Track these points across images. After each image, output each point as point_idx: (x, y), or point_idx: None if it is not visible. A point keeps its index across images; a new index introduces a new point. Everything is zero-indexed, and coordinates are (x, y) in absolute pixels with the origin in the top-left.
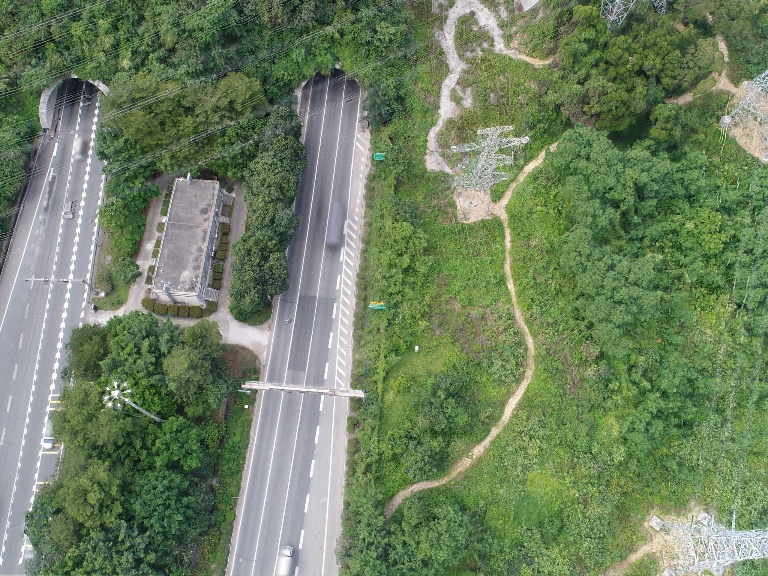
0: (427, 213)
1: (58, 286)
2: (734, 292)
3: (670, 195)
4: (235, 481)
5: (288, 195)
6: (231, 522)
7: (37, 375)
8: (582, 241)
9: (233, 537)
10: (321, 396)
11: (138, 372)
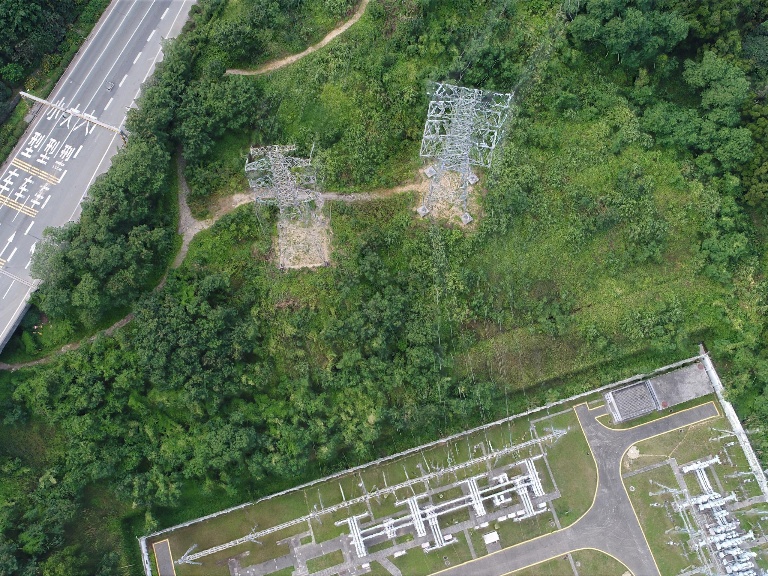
0: None
1: None
2: (565, 1)
3: None
4: (87, 26)
5: None
6: (73, 54)
7: None
8: None
9: (71, 65)
10: None
11: None
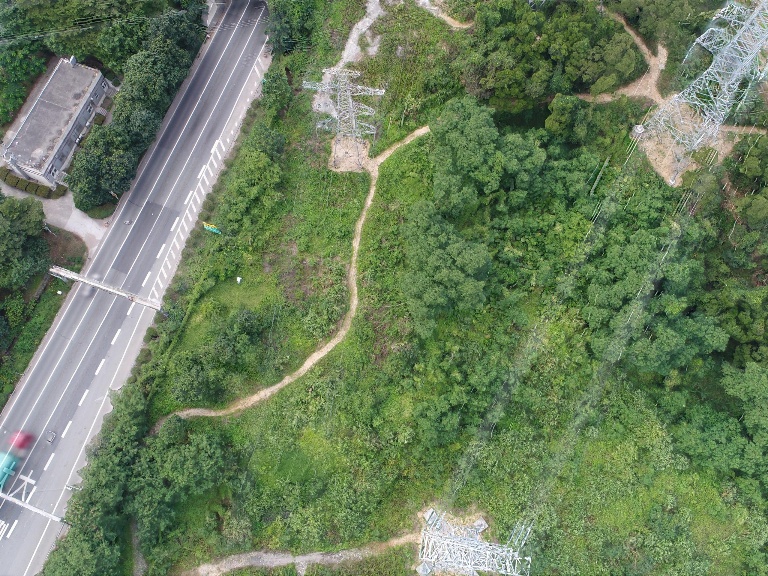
0: (298, 151)
1: None
2: (584, 308)
3: (550, 192)
4: (24, 358)
5: (152, 97)
6: (8, 395)
7: None
8: (422, 212)
9: (5, 409)
10: None
11: None
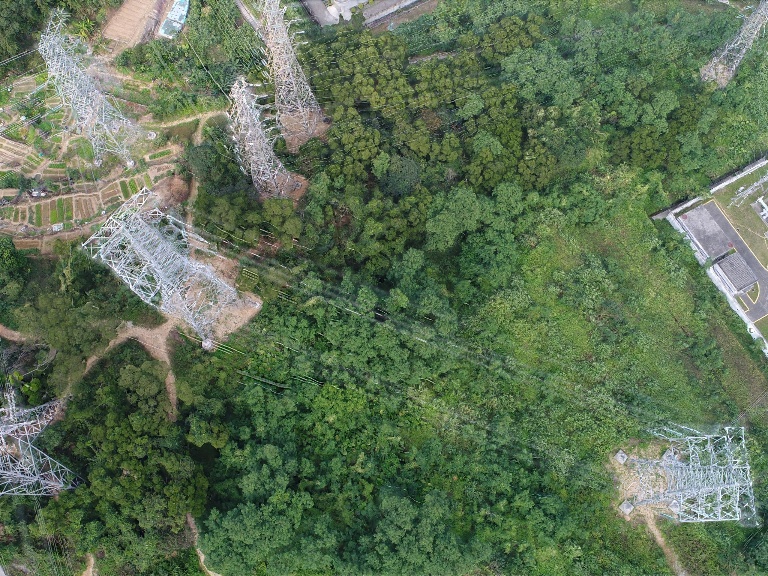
0: None
1: None
2: None
3: None
4: None
5: None
6: None
7: None
8: None
9: None
10: None
11: None
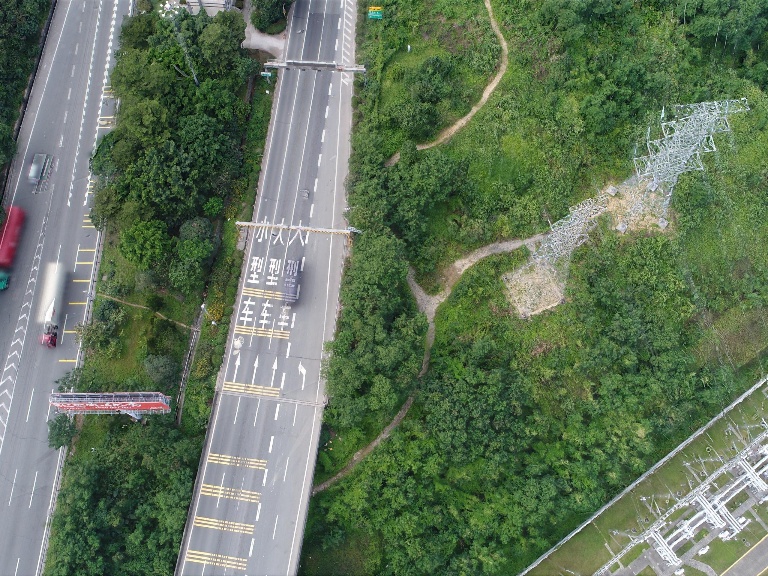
0: None
1: (106, 9)
2: (677, 7)
3: None
4: (260, 144)
5: None
6: (257, 173)
7: (92, 73)
8: None
9: (259, 184)
10: (330, 85)
11: (179, 43)
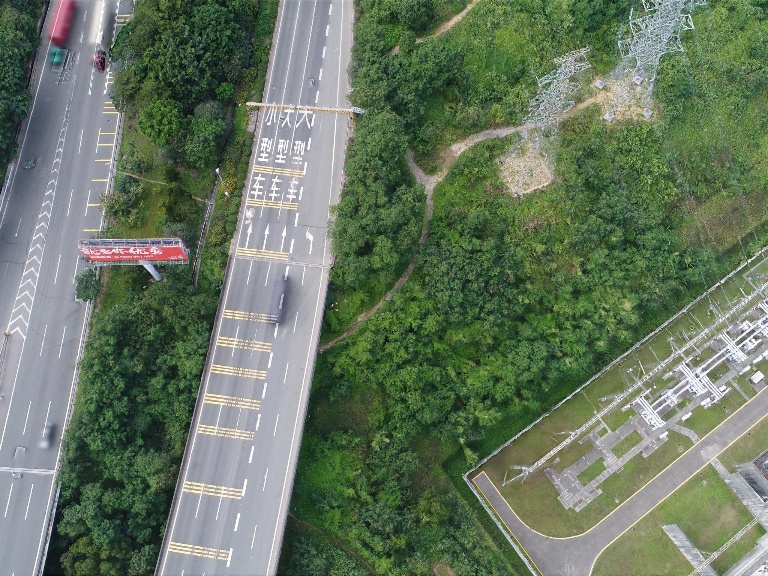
0: None
1: None
2: None
3: None
4: (268, 37)
5: None
6: (266, 64)
7: None
8: None
9: (268, 74)
10: None
11: None
